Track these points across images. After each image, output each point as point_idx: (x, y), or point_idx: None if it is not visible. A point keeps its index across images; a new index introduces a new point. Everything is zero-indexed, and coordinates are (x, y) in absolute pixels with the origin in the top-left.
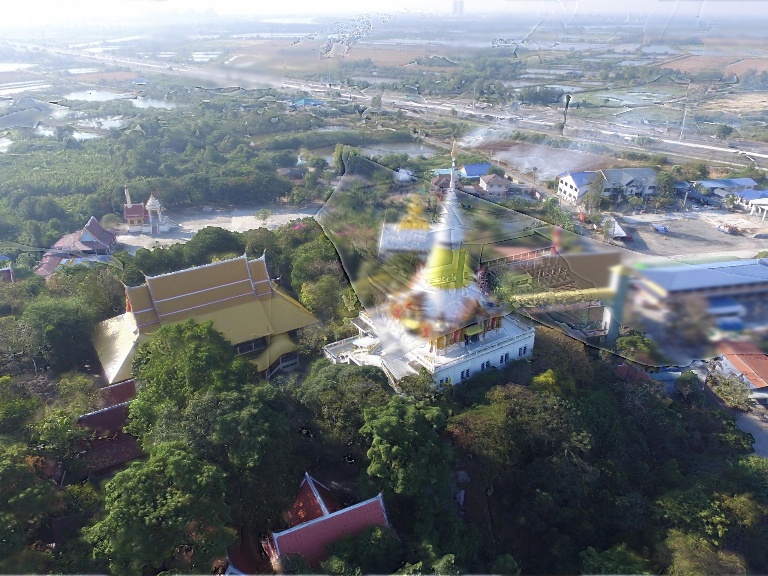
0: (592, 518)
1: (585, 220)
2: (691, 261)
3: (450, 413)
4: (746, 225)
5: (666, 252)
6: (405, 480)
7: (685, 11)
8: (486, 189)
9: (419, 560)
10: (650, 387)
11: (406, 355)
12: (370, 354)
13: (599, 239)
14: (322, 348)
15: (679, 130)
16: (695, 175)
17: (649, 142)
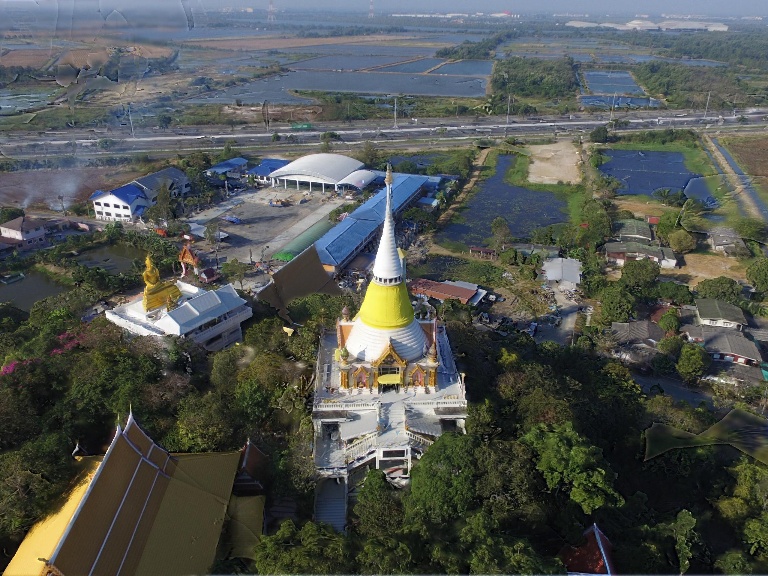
0: (597, 435)
1: (168, 234)
2: (308, 236)
3: (519, 427)
4: (282, 196)
5: (266, 238)
6: (616, 491)
7: (84, 6)
8: (22, 238)
9: (654, 543)
10: (473, 334)
11: (416, 411)
12: (381, 435)
13: (203, 247)
14: (314, 470)
15: (120, 127)
16: (201, 165)
17: (113, 144)
